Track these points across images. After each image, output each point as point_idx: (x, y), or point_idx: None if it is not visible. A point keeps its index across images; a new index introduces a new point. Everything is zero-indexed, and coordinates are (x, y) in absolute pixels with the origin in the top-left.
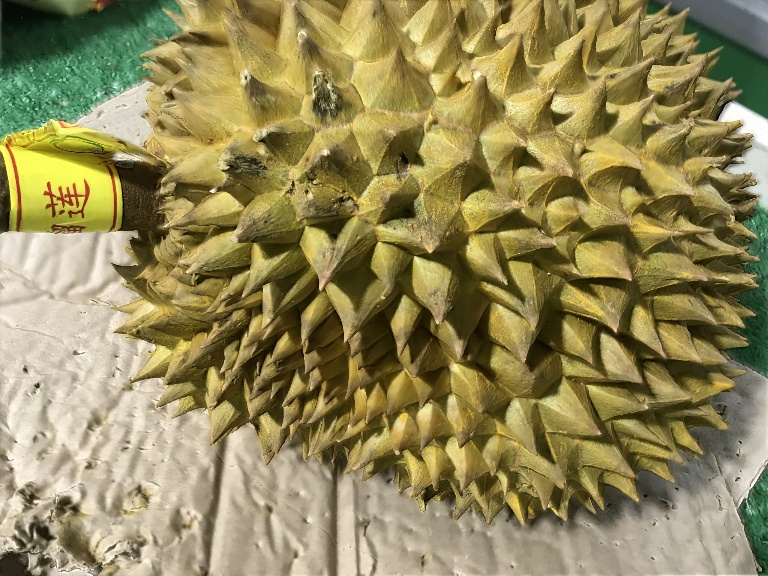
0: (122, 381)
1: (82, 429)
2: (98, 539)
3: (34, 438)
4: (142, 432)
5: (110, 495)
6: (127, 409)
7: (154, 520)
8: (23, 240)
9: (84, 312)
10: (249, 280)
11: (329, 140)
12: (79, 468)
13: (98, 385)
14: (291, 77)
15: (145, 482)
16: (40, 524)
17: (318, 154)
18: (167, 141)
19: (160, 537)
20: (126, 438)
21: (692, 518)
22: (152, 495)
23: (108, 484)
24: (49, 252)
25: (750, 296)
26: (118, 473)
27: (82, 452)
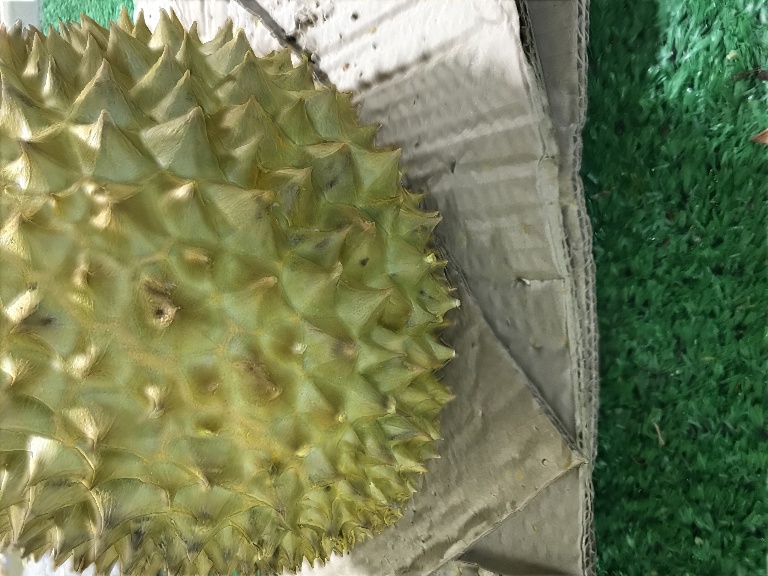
0: None
1: None
2: None
3: None
4: None
5: None
6: None
7: None
8: None
9: None
10: None
11: None
12: None
13: None
14: None
15: None
16: None
17: None
18: None
19: None
20: None
21: (335, 569)
22: None
23: None
24: None
25: None
26: None
27: None
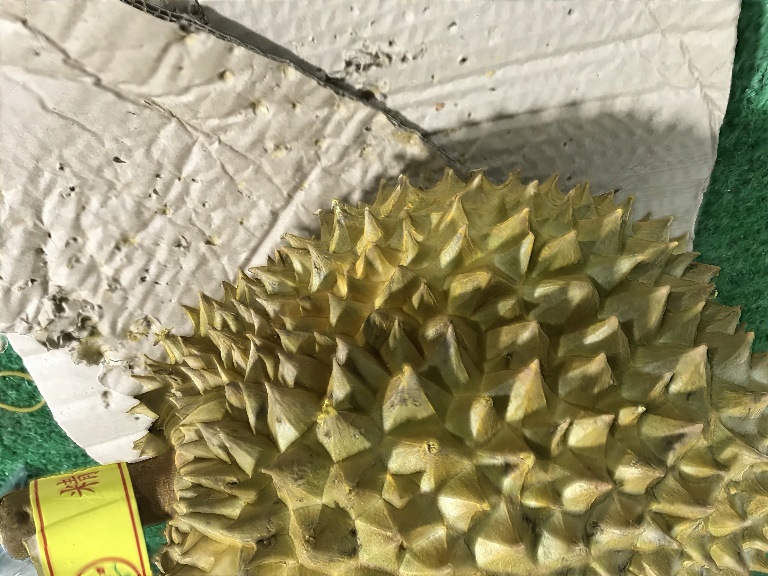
0: (157, 206)
1: (109, 249)
2: (107, 349)
3: (66, 244)
4: (161, 266)
5: (122, 322)
6: (154, 238)
7: (149, 352)
8: (64, 20)
9: (133, 113)
10: None
11: None
12: (102, 284)
13: (132, 205)
14: None
15: None
16: (66, 332)
17: None
18: None
19: None
20: (146, 267)
21: None
22: (154, 324)
23: (122, 312)
24: (98, 45)
25: (767, 347)
26: (132, 303)
27: (106, 267)
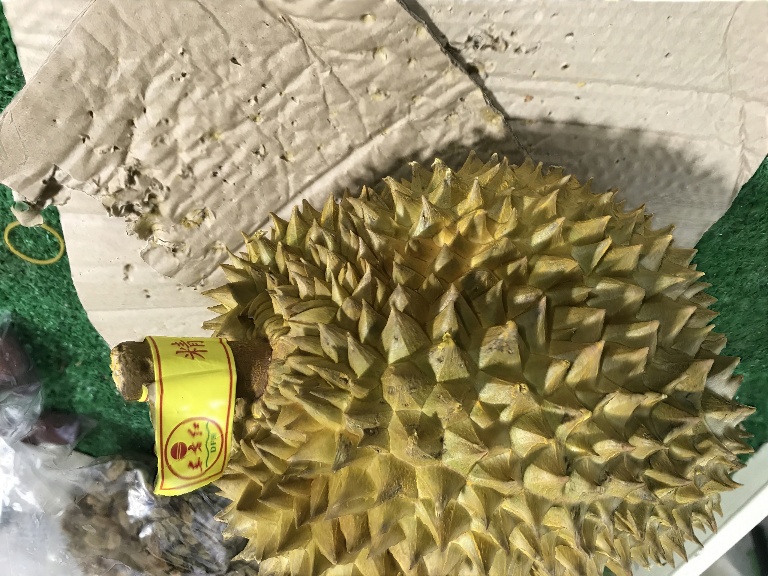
0: (251, 112)
1: (195, 138)
2: (159, 228)
3: (158, 123)
4: (235, 166)
5: (182, 207)
6: (238, 139)
7: (197, 241)
8: None
9: (267, 23)
10: (223, 494)
11: (277, 566)
12: (176, 168)
13: (231, 104)
14: (290, 557)
15: (210, 210)
16: (130, 203)
17: (259, 573)
18: (243, 451)
19: (193, 252)
20: (221, 164)
21: None
22: (209, 217)
23: (186, 198)
24: None
25: None
26: (197, 192)
27: (185, 154)
